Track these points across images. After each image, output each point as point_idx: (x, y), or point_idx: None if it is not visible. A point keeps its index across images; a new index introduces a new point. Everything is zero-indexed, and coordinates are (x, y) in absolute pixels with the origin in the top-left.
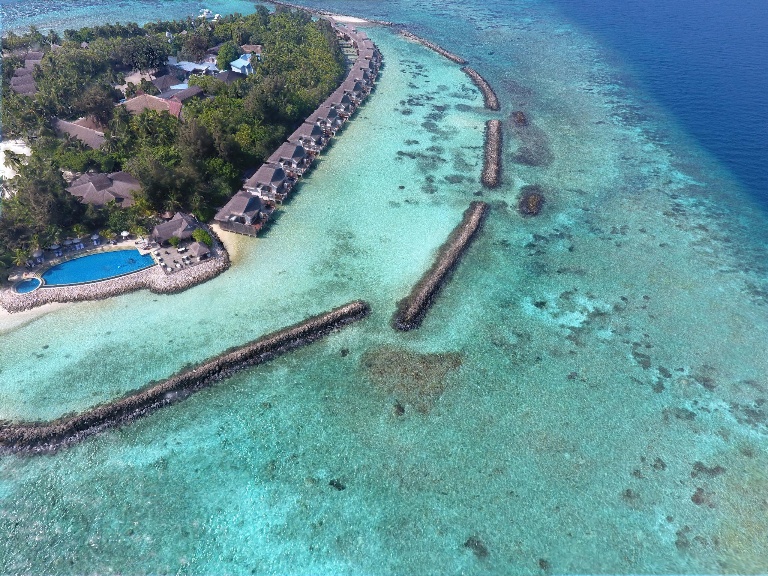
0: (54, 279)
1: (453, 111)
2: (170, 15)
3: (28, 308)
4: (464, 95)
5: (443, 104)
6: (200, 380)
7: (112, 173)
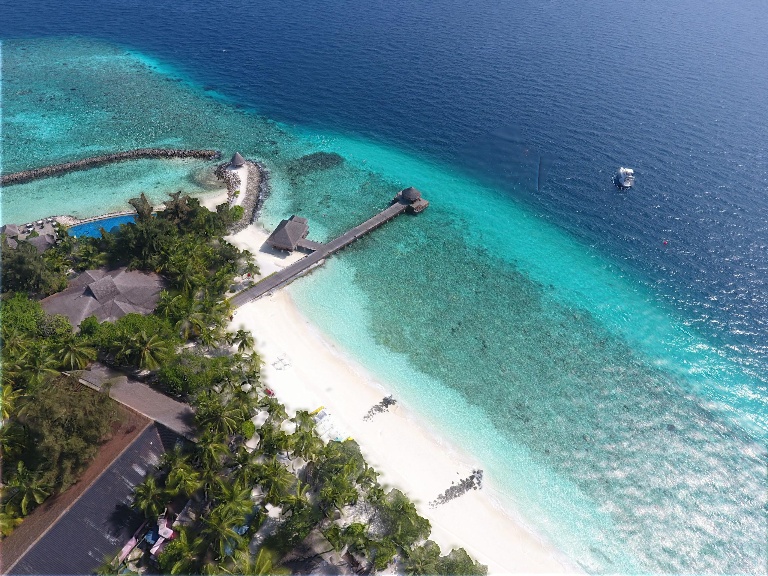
0: None
1: None
2: None
3: None
4: None
5: None
6: None
7: None
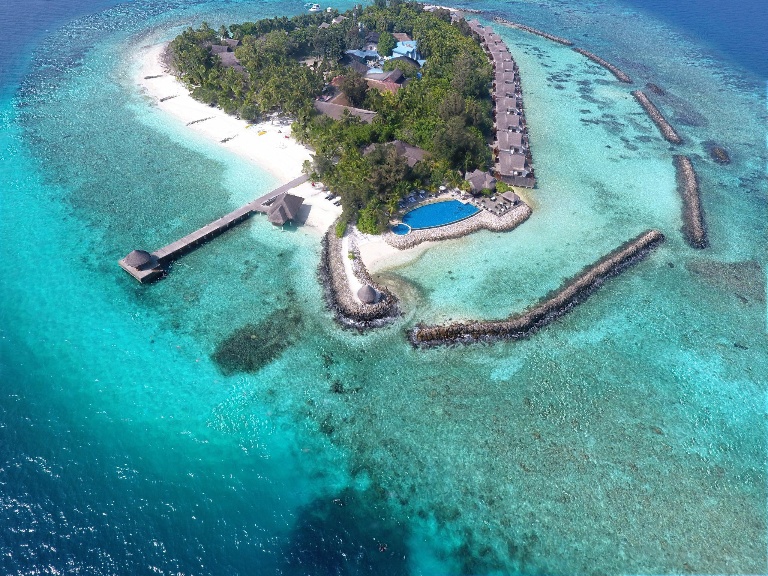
0: (414, 224)
1: (596, 85)
2: (279, 10)
3: (411, 246)
4: (594, 71)
5: (583, 79)
6: (588, 287)
7: None
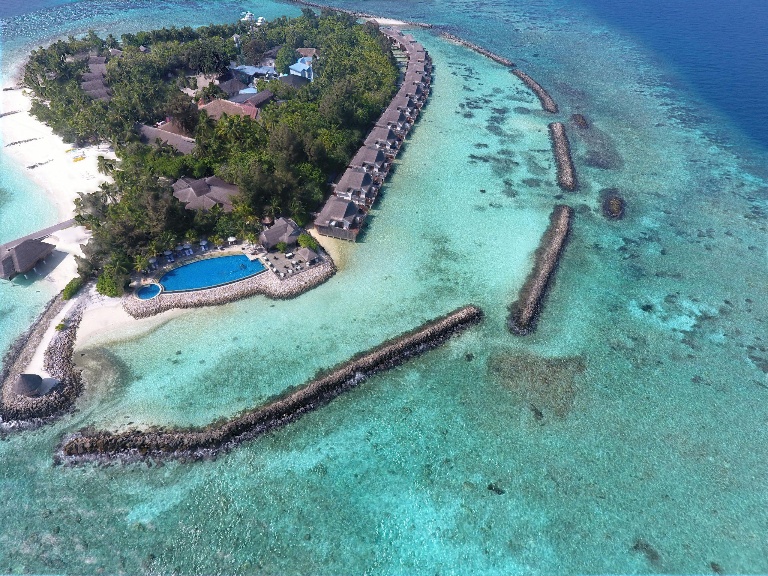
0: (172, 285)
1: (513, 114)
2: (212, 18)
3: (152, 314)
4: (520, 98)
5: (502, 107)
6: (338, 385)
7: (204, 178)
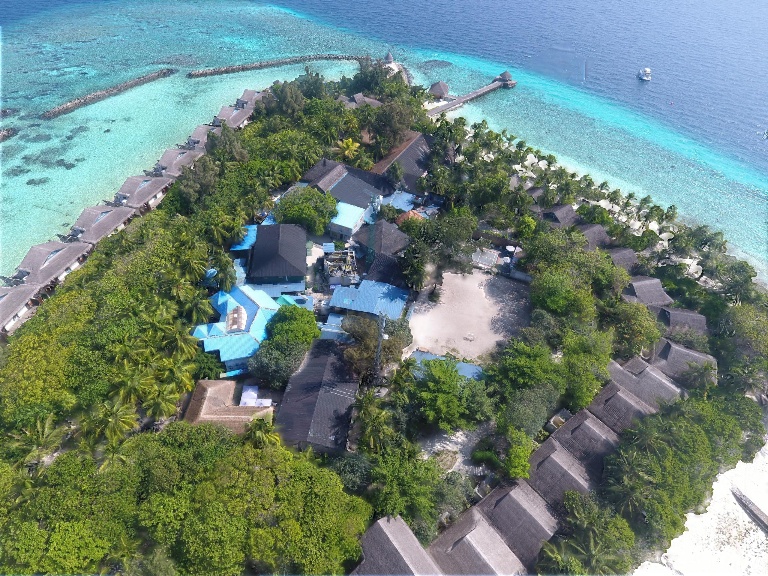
0: None
1: None
2: None
3: None
4: None
5: None
6: None
7: None
